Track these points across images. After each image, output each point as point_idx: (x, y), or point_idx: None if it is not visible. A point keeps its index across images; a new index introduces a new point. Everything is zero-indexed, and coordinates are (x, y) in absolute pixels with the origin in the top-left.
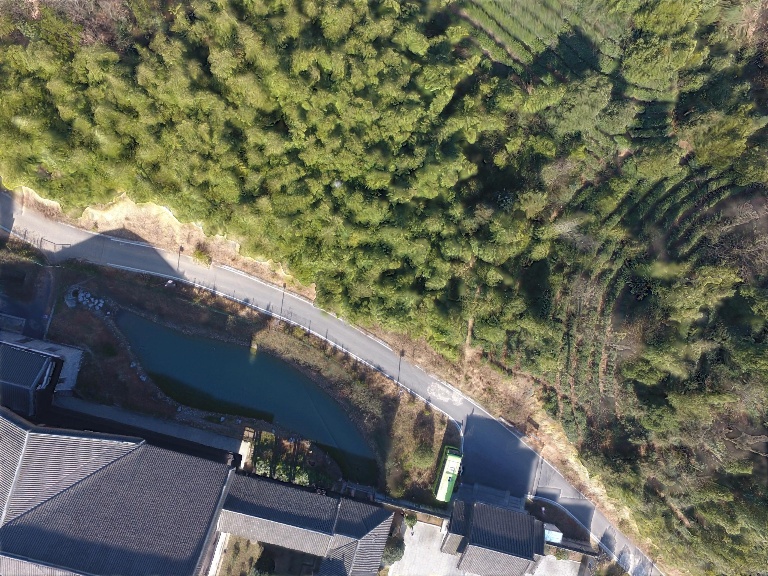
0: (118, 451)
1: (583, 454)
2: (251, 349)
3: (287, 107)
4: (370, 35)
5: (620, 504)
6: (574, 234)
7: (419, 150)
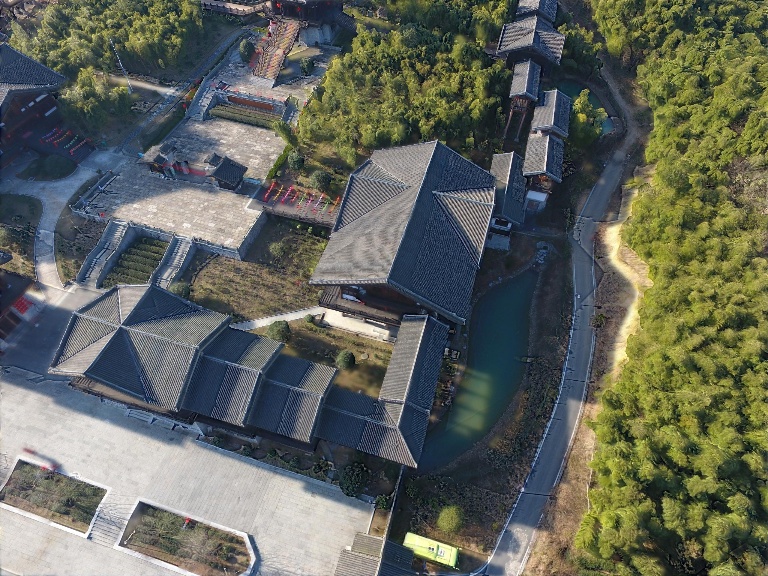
0: (474, 253)
1: None
2: (526, 358)
3: None
4: None
5: None
6: None
7: None
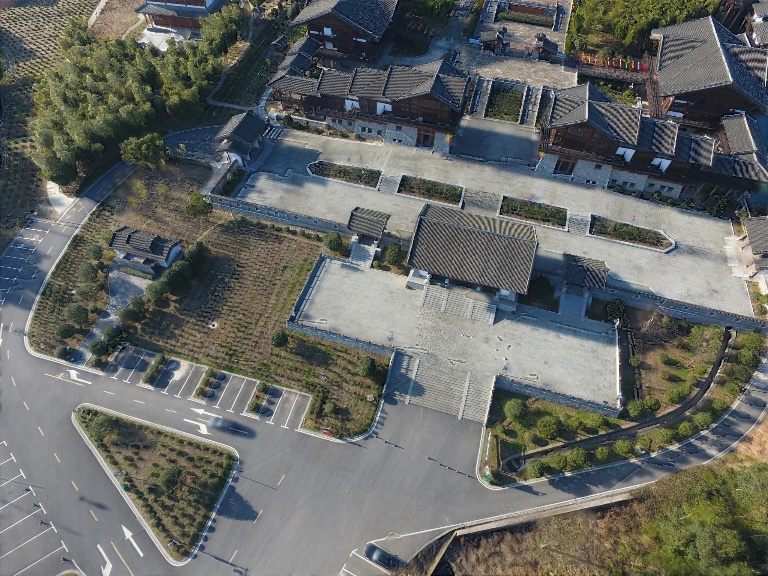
0: (760, 80)
1: None
2: None
3: None
4: None
5: None
6: None
7: None
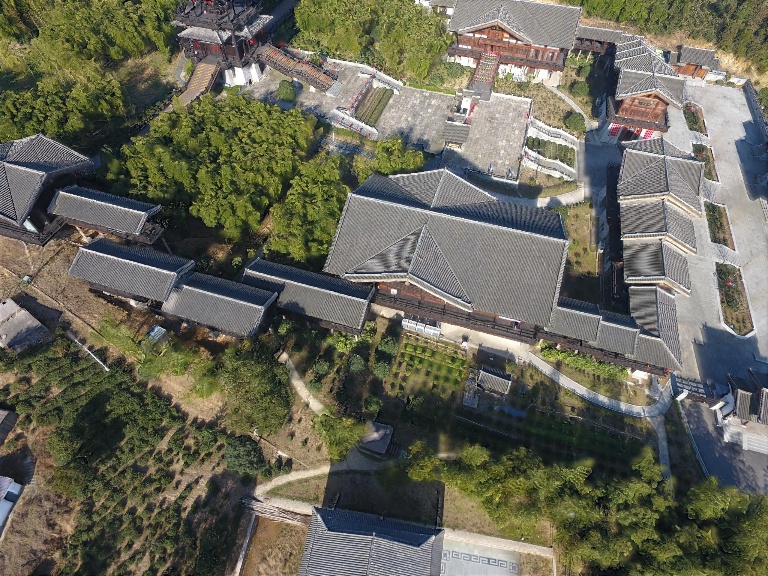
0: None
1: (719, 40)
2: None
3: None
4: None
5: (748, 67)
6: None
7: None
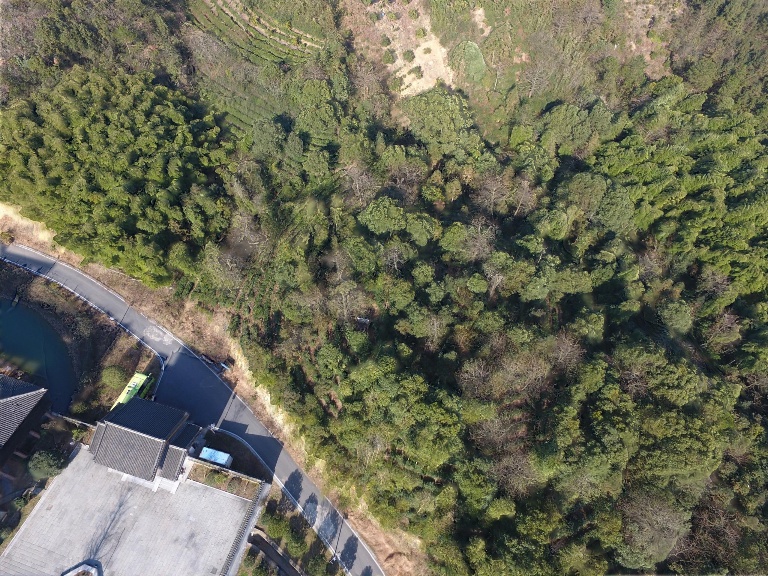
0: None
1: None
2: (13, 302)
3: (75, 129)
4: (142, 107)
5: (295, 428)
6: (266, 210)
7: (154, 153)
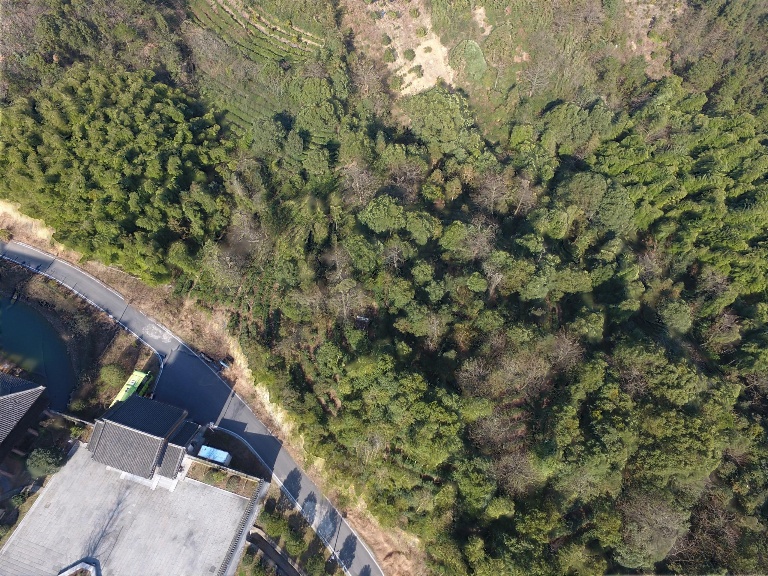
0: None
1: None
2: (12, 300)
3: (75, 126)
4: (142, 104)
5: (294, 427)
6: (266, 208)
7: (154, 151)
